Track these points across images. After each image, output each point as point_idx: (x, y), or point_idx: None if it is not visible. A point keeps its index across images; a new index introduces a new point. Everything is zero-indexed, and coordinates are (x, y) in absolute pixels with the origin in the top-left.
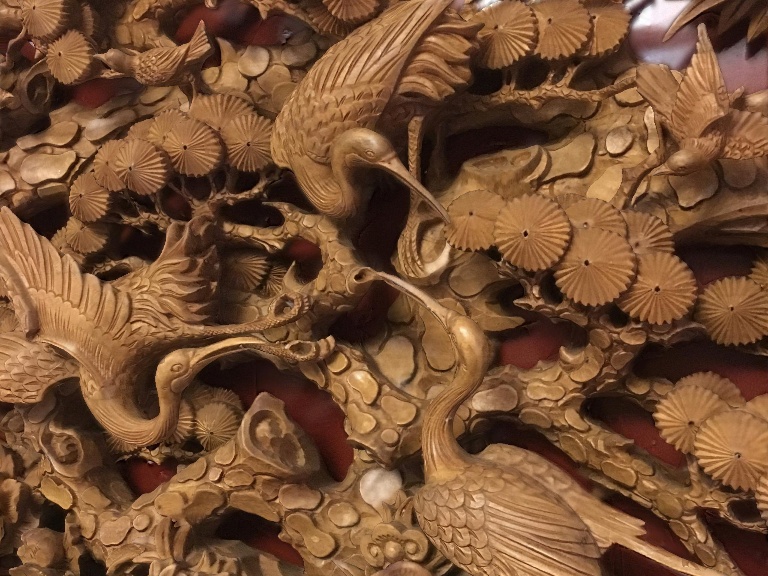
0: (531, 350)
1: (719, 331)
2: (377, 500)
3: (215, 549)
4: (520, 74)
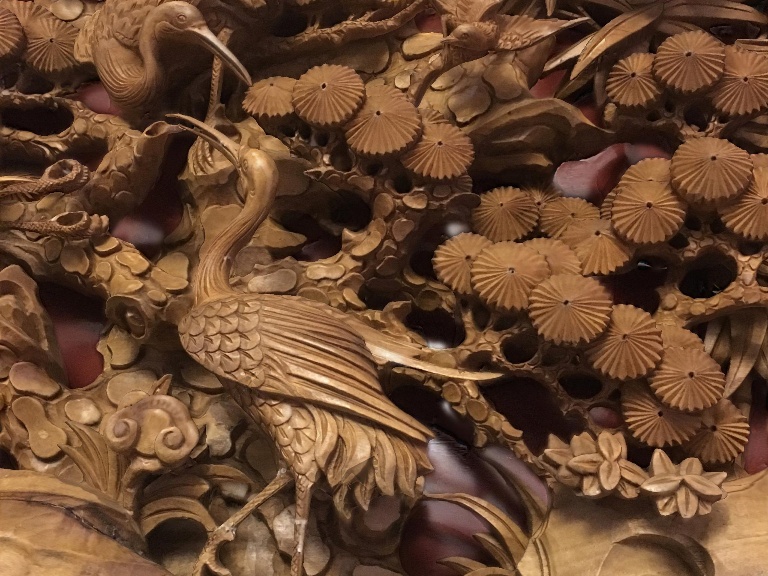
0: None
1: (490, 229)
2: None
3: None
4: (324, 19)
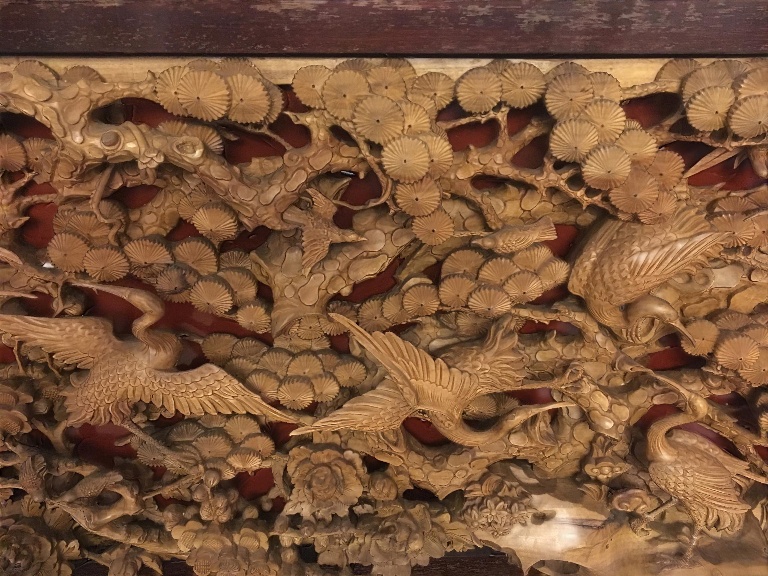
0: (667, 358)
1: None
2: (583, 438)
3: None
4: None
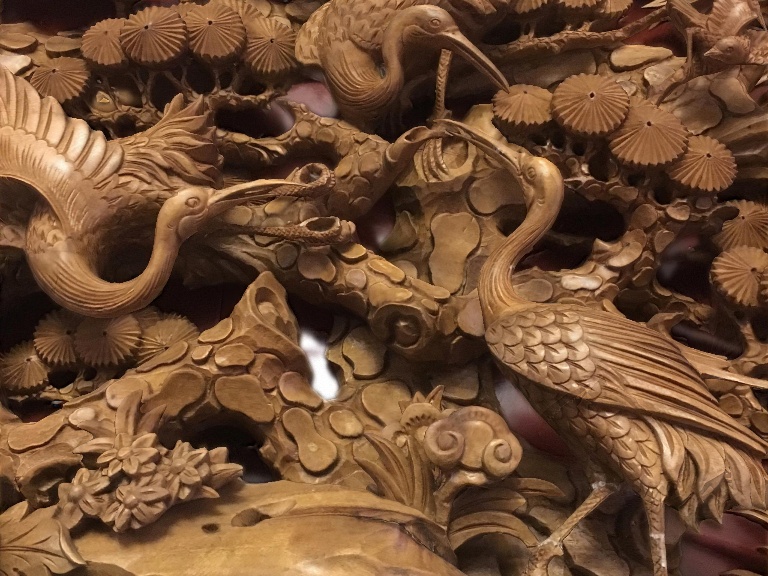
0: None
1: (731, 241)
2: (384, 411)
3: None
4: (537, 28)
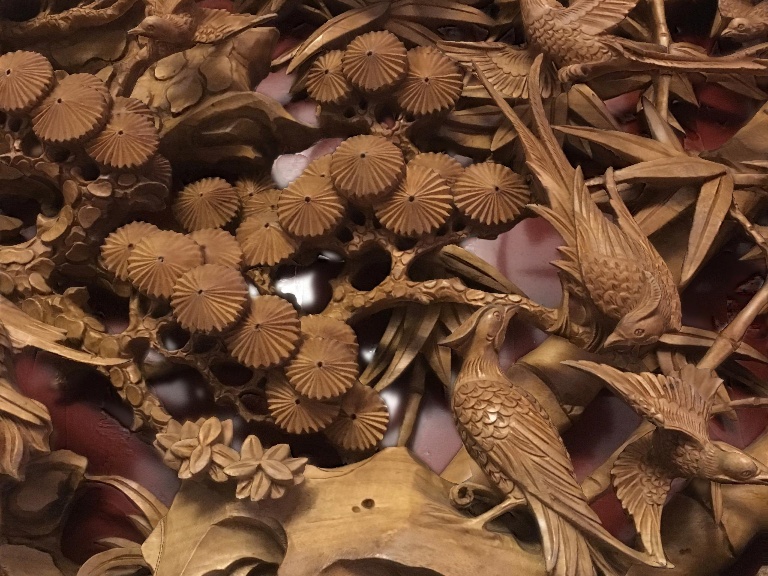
0: None
1: (190, 218)
2: None
3: None
4: (56, 5)
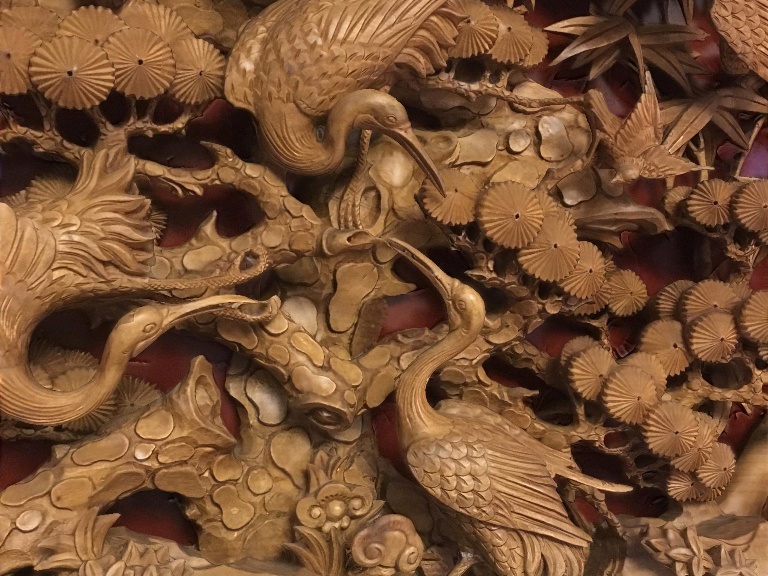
0: (414, 314)
1: None
2: (289, 463)
3: (120, 539)
4: (458, 66)
